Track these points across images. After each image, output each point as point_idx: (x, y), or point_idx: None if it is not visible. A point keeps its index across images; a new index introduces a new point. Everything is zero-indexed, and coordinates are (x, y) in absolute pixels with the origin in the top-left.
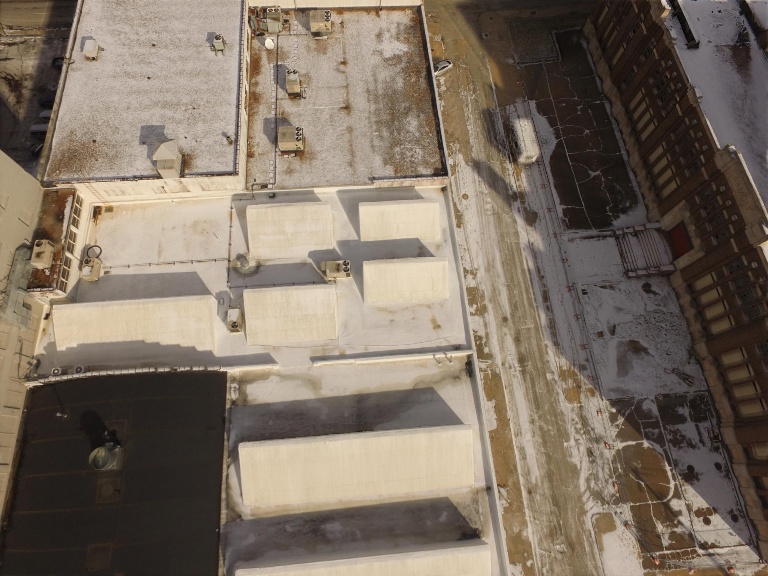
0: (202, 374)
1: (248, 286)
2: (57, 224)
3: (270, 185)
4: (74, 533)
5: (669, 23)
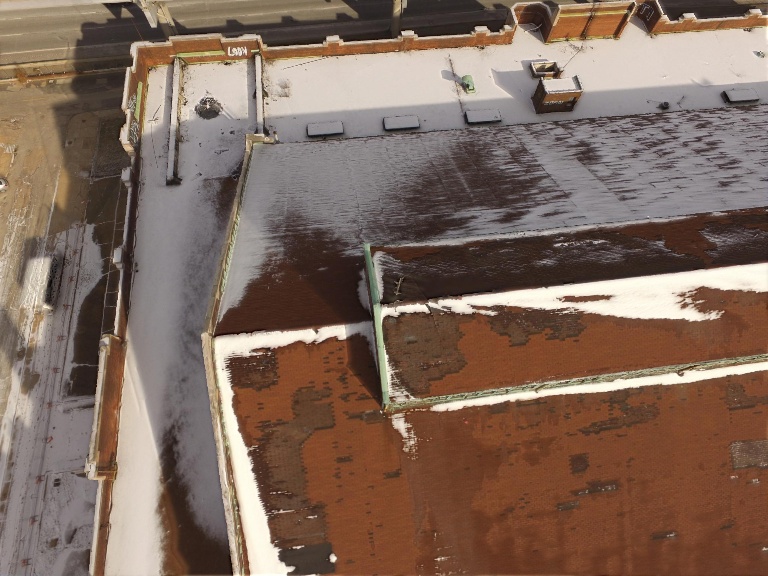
0: None
1: None
2: None
3: None
4: None
5: (160, 152)
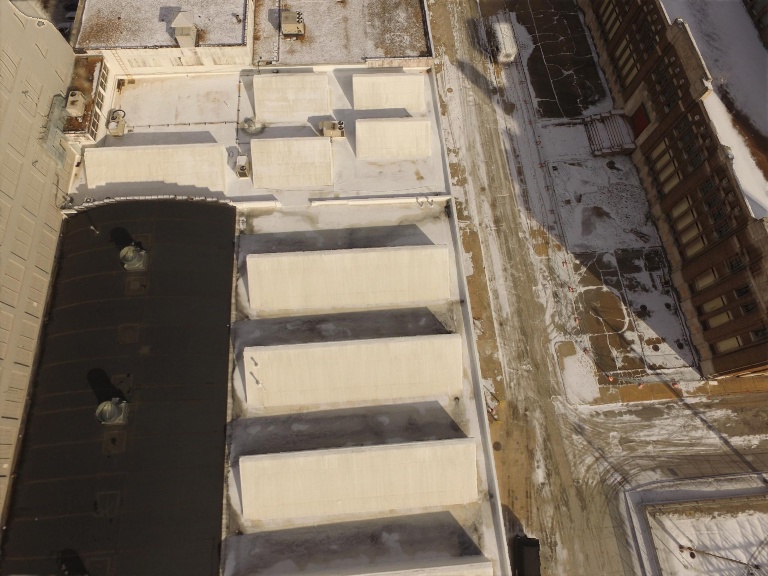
0: (215, 206)
1: None
2: (88, 83)
3: (274, 62)
4: (107, 317)
5: None
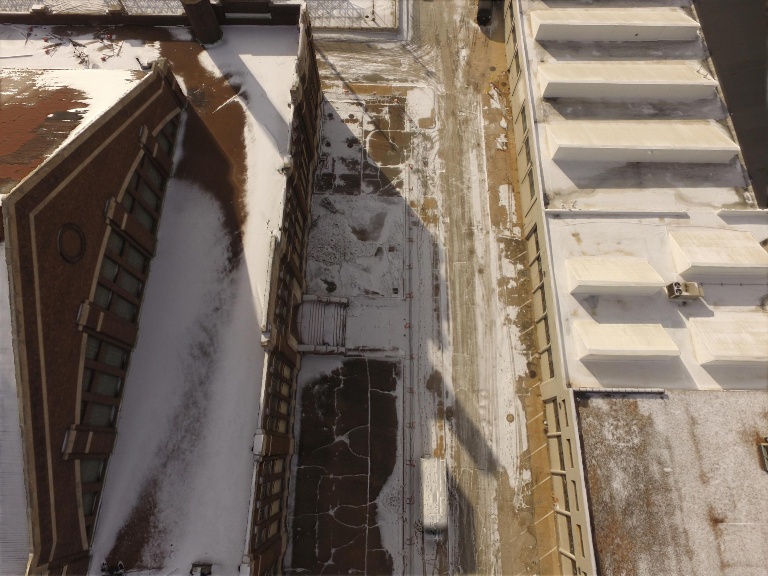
0: None
1: (767, 285)
2: None
3: None
4: None
5: None
